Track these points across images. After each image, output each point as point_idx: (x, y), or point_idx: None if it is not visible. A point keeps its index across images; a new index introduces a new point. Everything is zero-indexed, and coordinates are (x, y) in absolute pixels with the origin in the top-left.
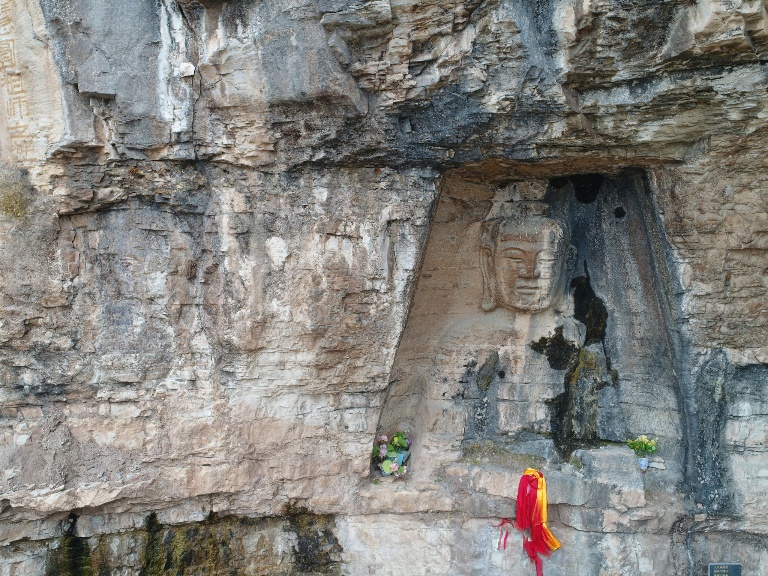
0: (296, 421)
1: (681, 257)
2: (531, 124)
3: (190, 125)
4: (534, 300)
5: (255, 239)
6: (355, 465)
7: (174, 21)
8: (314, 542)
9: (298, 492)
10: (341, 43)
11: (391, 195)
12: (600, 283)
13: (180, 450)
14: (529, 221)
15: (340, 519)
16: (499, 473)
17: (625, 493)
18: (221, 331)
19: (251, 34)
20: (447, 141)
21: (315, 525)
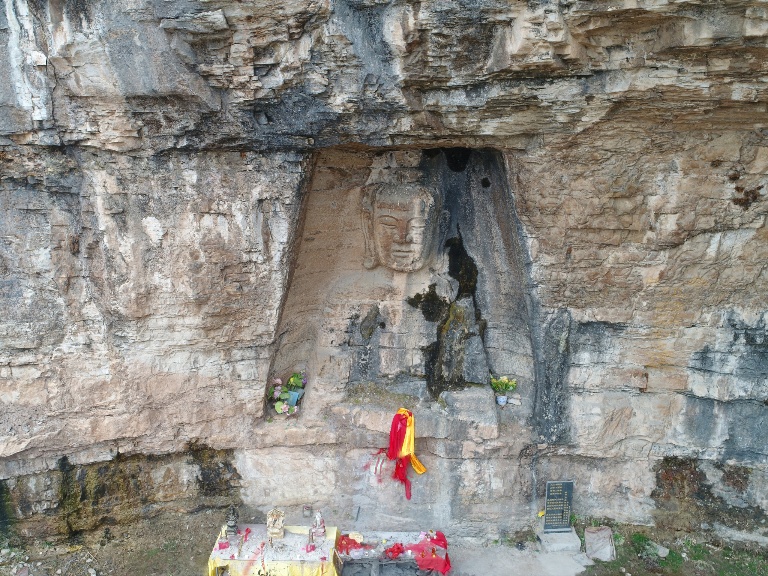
0: (190, 374)
1: (529, 233)
2: (380, 119)
3: (50, 114)
4: (408, 262)
5: (131, 218)
6: (248, 408)
7: (20, 7)
8: (215, 472)
9: (197, 433)
10: (184, 46)
11: (259, 176)
12: (471, 244)
13: (82, 404)
14: (402, 190)
15: (238, 452)
16: (376, 412)
17: (481, 428)
18: (108, 302)
19: (95, 30)
20: (303, 133)
21: (216, 458)
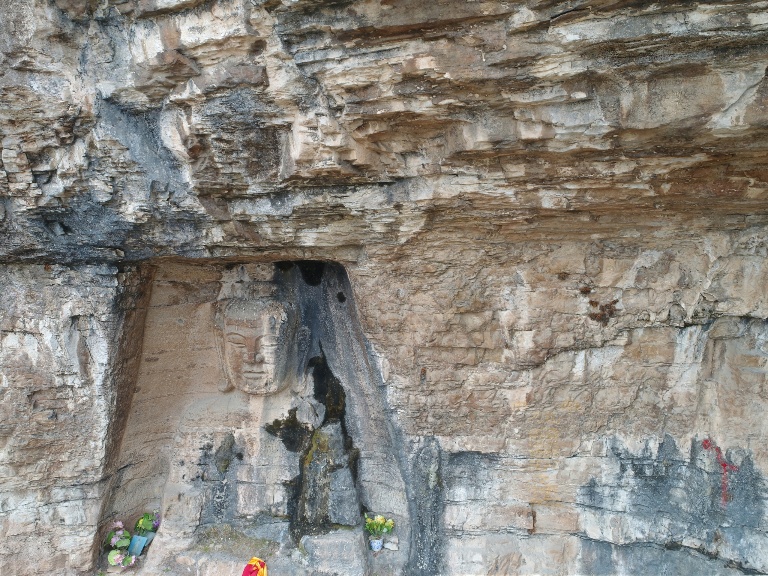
0: None
1: (377, 352)
2: (186, 229)
3: None
4: (260, 385)
5: None
6: (71, 560)
7: None
8: None
9: None
10: None
11: (70, 291)
12: (335, 364)
13: None
14: (250, 306)
15: None
16: (225, 562)
17: None
18: None
19: None
20: (105, 244)
21: None
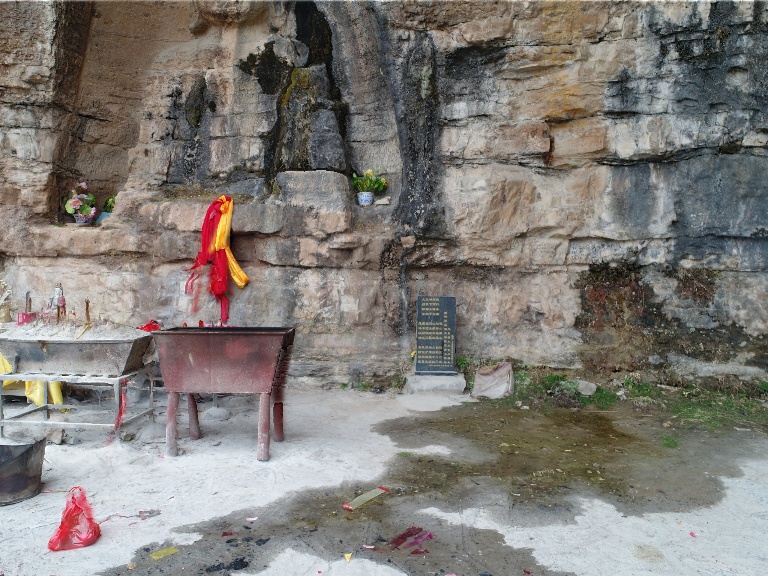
0: None
1: None
2: None
3: None
4: (230, 0)
5: None
6: (22, 195)
7: None
8: None
9: None
10: None
11: None
12: None
13: None
14: None
15: (10, 262)
16: (189, 204)
17: (323, 216)
18: None
19: None
20: None
21: None
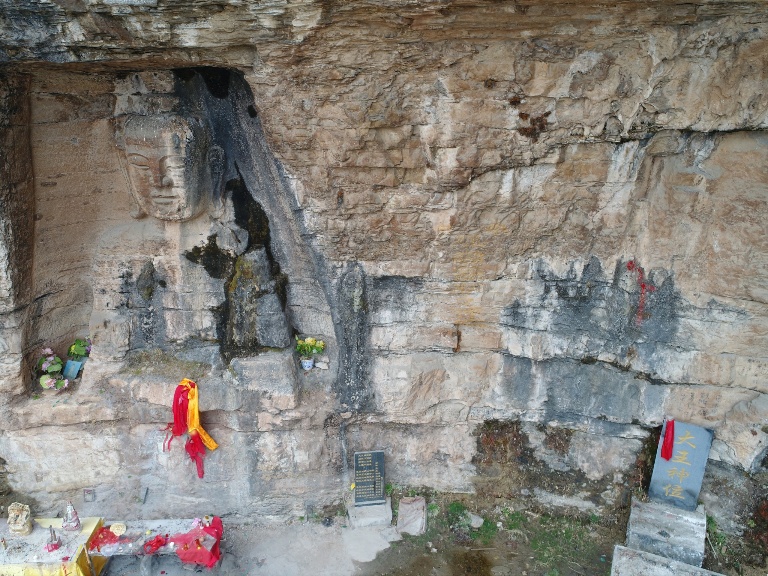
0: None
1: (289, 173)
2: (35, 24)
3: None
4: (172, 210)
5: None
6: (0, 385)
7: None
8: None
9: None
10: None
11: None
12: (254, 187)
13: None
14: (149, 122)
15: None
16: (157, 384)
17: (275, 398)
18: None
19: None
20: None
21: None
